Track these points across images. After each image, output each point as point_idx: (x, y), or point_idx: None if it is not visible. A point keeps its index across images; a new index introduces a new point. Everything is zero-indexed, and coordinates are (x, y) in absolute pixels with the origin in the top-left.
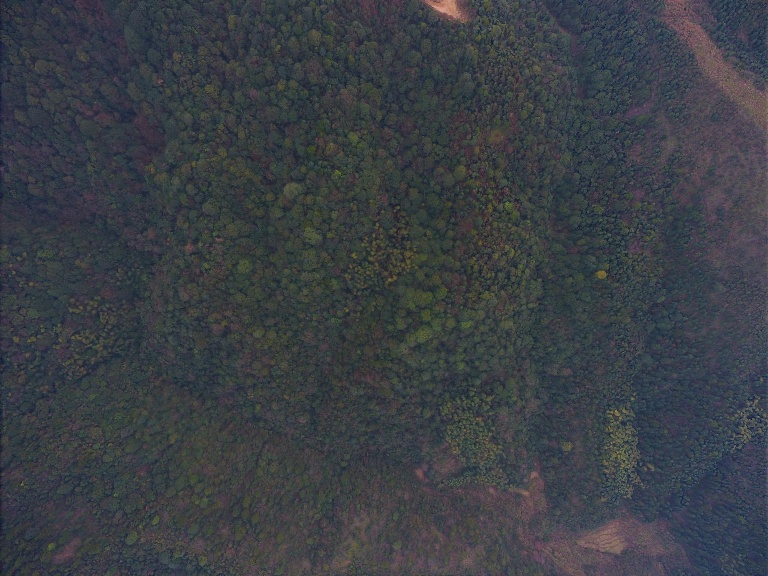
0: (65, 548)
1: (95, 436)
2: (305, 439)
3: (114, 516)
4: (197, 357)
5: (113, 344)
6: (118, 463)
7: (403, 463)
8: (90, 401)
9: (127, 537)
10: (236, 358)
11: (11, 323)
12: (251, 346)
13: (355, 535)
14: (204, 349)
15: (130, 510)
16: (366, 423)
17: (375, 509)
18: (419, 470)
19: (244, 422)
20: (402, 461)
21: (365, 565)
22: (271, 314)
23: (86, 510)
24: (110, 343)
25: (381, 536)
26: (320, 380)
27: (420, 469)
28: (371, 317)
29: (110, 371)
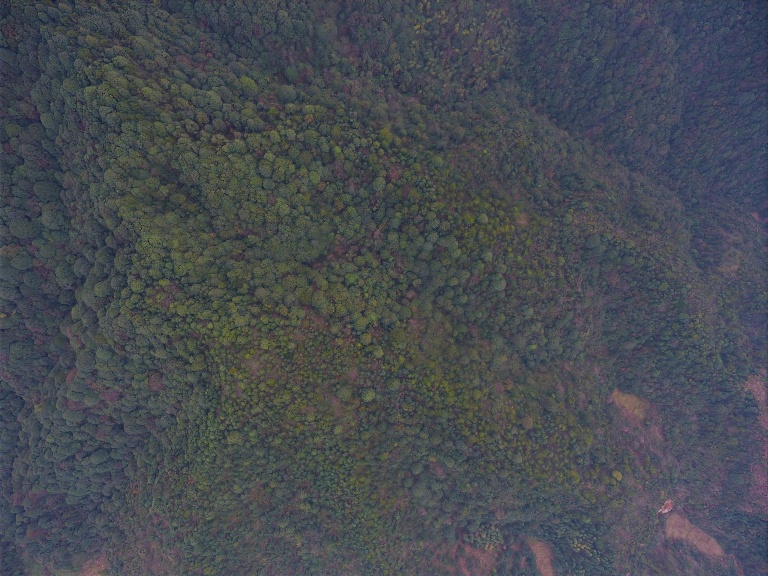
0: (520, 217)
1: (521, 128)
2: (657, 176)
3: (543, 203)
4: (596, 66)
5: (506, 62)
6: (537, 159)
7: (743, 204)
8: (501, 105)
9: (566, 215)
10: (636, 64)
11: (457, 9)
12: (657, 47)
13: (739, 243)
14: (603, 58)
15: (557, 198)
16: (732, 147)
17: (743, 229)
18: (754, 214)
19: (607, 155)
20: (743, 201)
21: (751, 271)
22: (667, 23)
23: (520, 195)
24: (508, 58)
25: (758, 249)
26: (682, 110)
27: (756, 213)
28: (767, 20)
29: (504, 88)
